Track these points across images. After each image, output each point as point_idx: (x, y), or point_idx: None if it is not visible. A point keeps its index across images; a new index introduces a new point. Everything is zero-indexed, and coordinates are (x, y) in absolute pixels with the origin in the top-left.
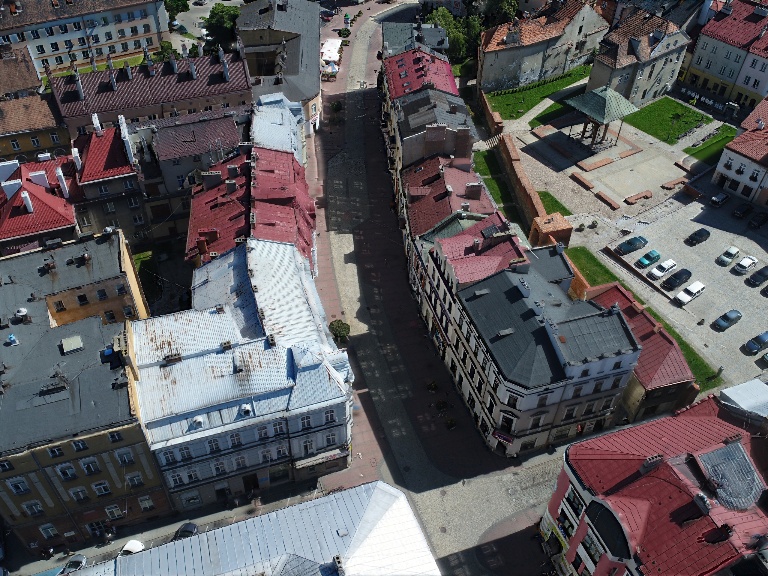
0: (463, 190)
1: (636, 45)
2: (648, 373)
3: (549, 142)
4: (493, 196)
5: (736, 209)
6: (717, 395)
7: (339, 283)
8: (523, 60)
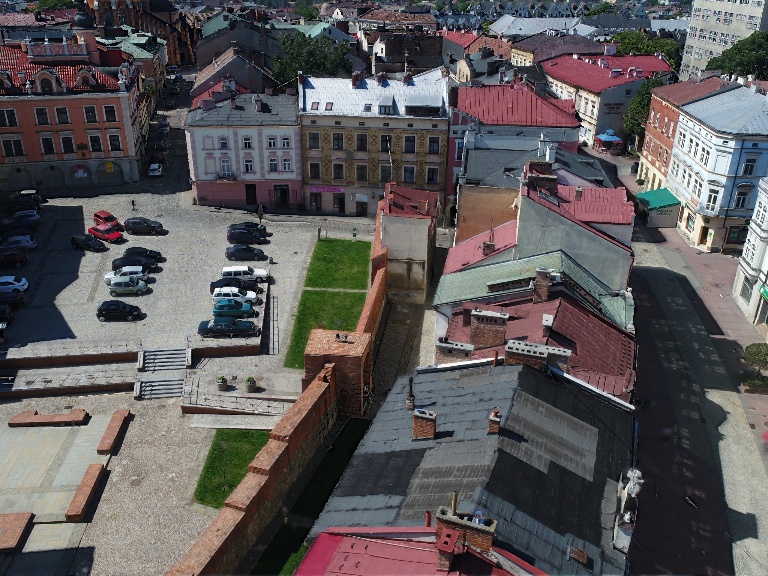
0: (501, 355)
1: None
2: (429, 194)
3: None
4: None
5: (6, 310)
6: (338, 235)
7: (766, 476)
8: None
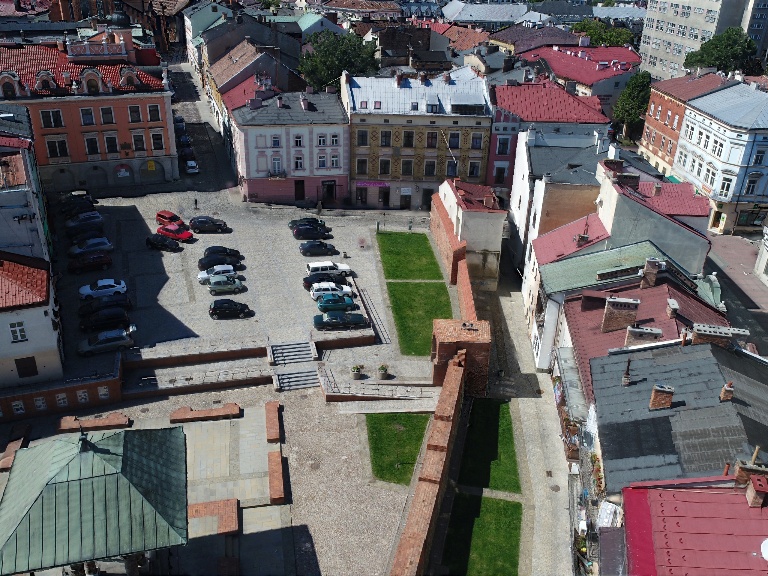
0: None
1: None
2: (483, 188)
3: None
4: (497, 523)
5: None
6: (393, 228)
7: None
8: None
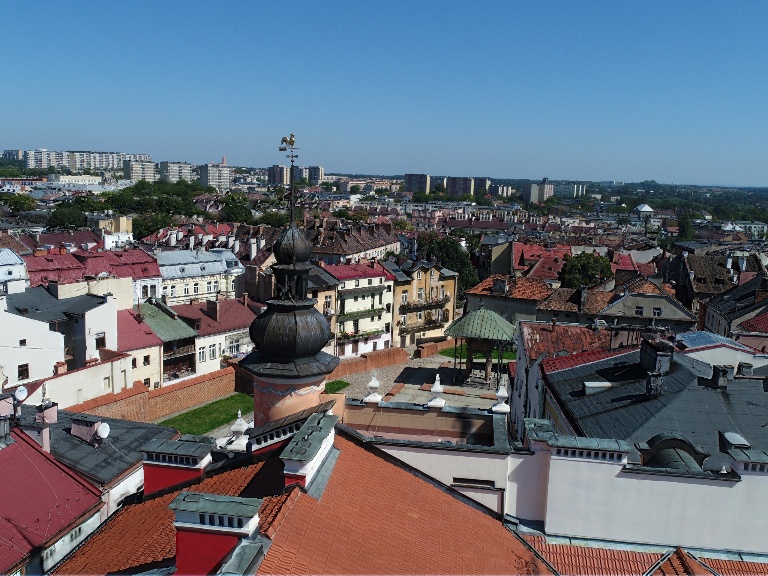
0: None
1: (581, 293)
2: None
3: (439, 370)
4: None
5: None
6: None
7: None
8: (515, 316)
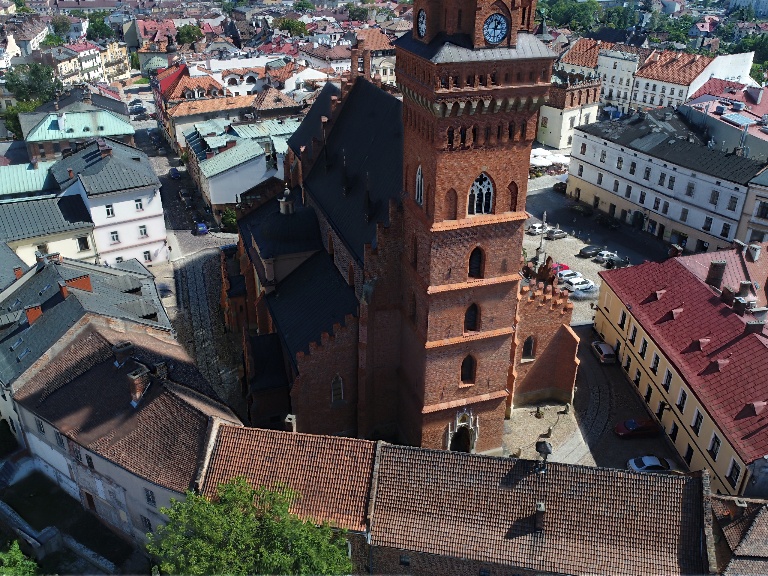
0: None
1: (194, 45)
2: None
3: None
4: None
5: None
6: None
7: None
8: None
